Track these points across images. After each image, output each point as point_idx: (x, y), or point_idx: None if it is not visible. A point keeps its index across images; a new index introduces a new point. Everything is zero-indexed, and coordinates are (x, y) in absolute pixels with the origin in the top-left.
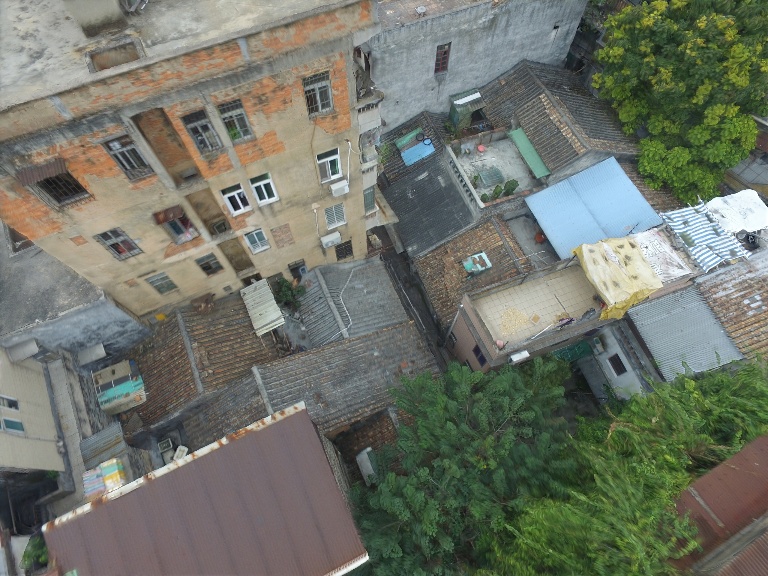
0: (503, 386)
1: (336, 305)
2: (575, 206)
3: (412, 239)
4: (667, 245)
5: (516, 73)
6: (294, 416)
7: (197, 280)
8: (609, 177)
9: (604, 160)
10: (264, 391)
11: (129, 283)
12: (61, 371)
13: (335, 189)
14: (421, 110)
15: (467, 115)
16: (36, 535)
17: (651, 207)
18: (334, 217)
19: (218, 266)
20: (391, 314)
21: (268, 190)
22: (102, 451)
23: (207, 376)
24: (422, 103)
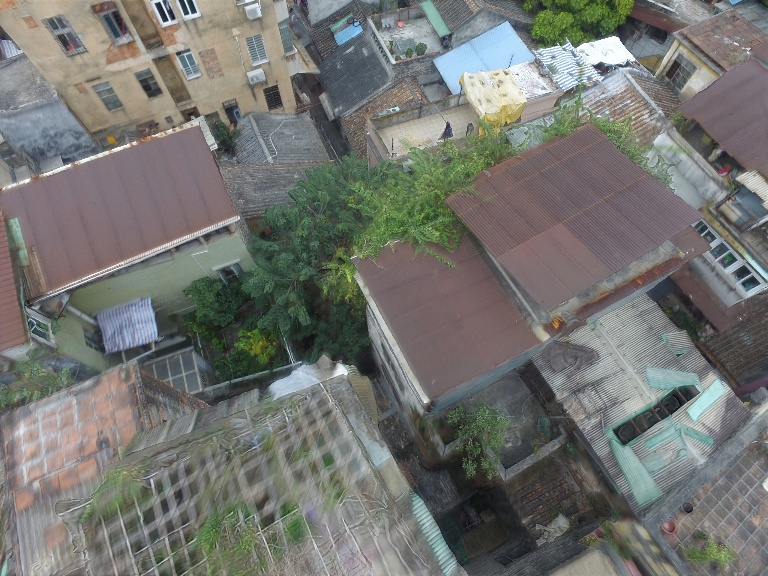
0: (381, 162)
1: (265, 141)
2: (473, 62)
3: (339, 101)
4: (536, 74)
5: None
6: (190, 130)
7: (139, 100)
8: (503, 38)
9: (500, 24)
10: None
11: (79, 88)
12: (25, 174)
13: (248, 10)
14: None
15: (394, 4)
16: None
17: None
18: (256, 52)
19: (157, 89)
20: (315, 156)
21: (190, 3)
22: None
23: None
24: None
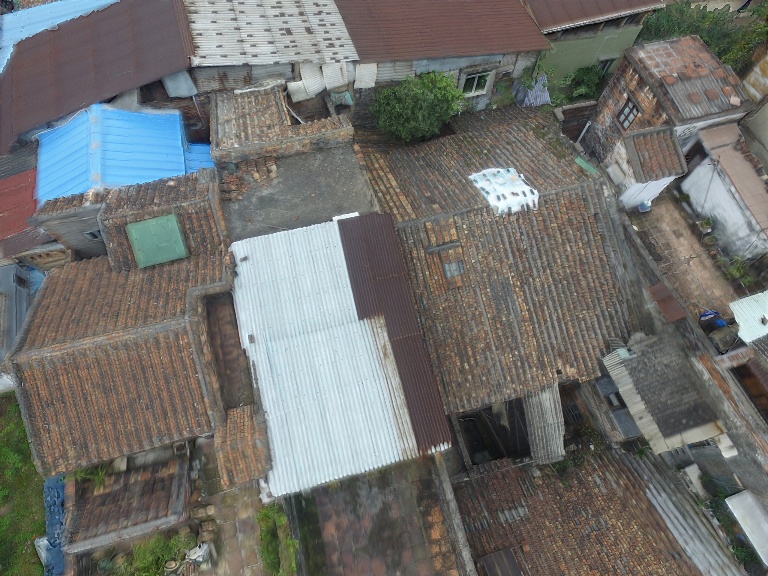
0: (710, 12)
1: None
2: None
3: None
4: None
5: None
6: None
7: None
8: None
9: None
10: None
11: None
12: None
13: None
14: None
15: None
16: None
17: None
18: None
19: None
20: None
21: None
22: None
23: None
24: None
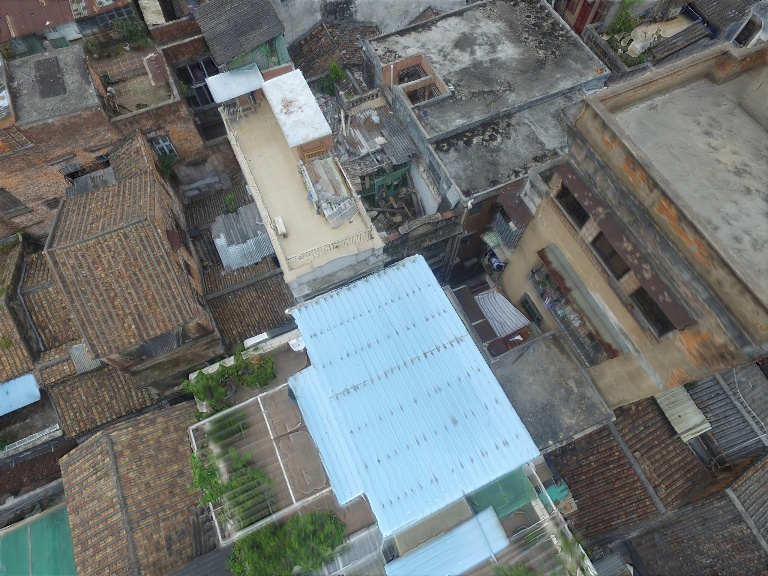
0: None
1: (742, 405)
2: None
3: None
4: None
5: None
6: None
7: None
8: None
9: None
10: (750, 519)
11: None
12: None
13: None
14: None
15: None
16: None
17: None
18: None
19: None
20: None
21: None
22: None
23: (664, 492)
24: None
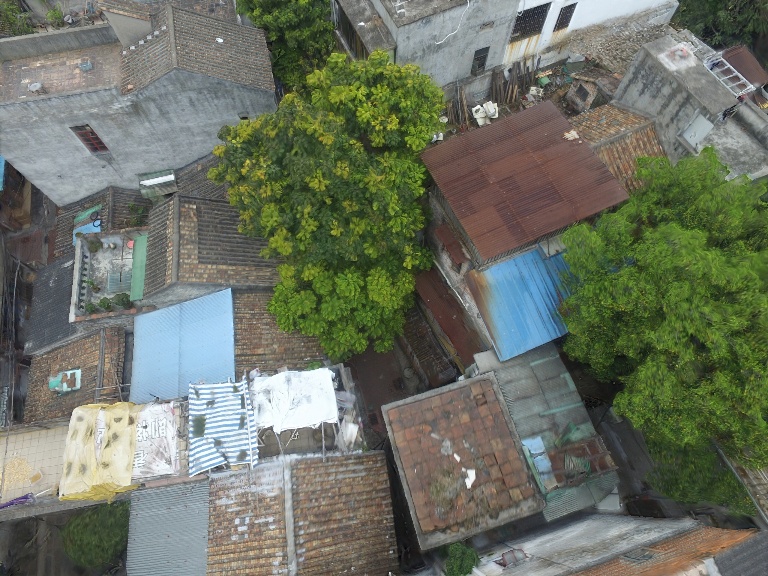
0: None
1: None
2: (171, 340)
3: (32, 334)
4: (173, 428)
5: (214, 160)
6: None
7: None
8: (216, 313)
9: (221, 290)
10: None
11: None
12: None
13: None
14: (105, 185)
15: (161, 197)
16: None
17: (233, 362)
18: None
19: None
20: None
21: None
22: None
23: None
24: (100, 179)
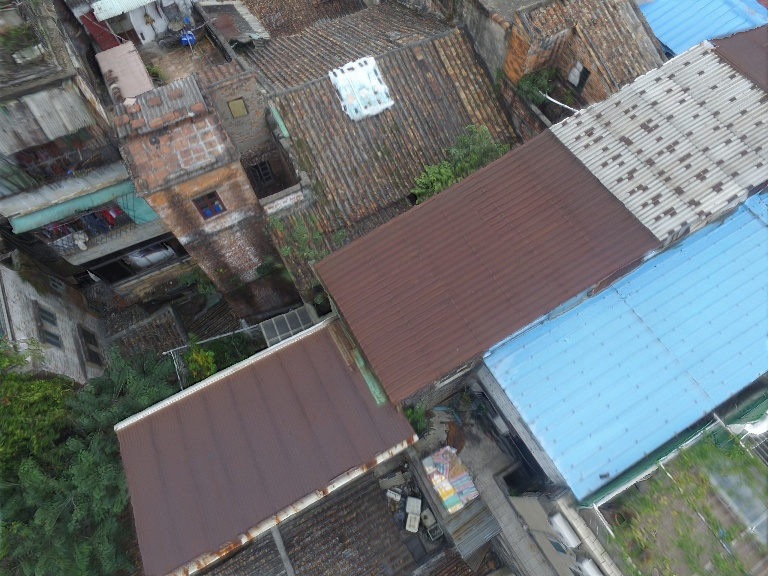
0: None
1: None
2: None
3: None
4: None
5: None
6: (162, 575)
7: None
8: None
9: None
10: None
11: None
12: None
13: None
14: None
15: None
16: (422, 431)
17: None
18: None
19: None
20: None
21: None
22: (472, 521)
23: None
24: None
